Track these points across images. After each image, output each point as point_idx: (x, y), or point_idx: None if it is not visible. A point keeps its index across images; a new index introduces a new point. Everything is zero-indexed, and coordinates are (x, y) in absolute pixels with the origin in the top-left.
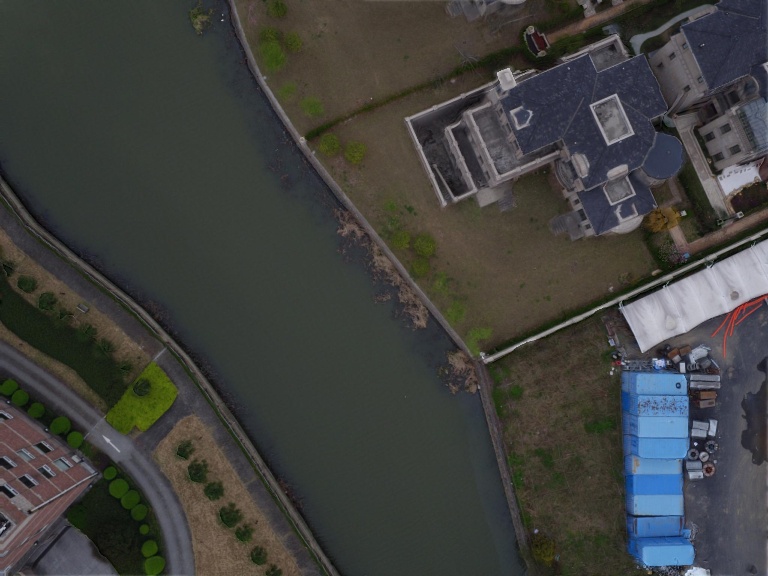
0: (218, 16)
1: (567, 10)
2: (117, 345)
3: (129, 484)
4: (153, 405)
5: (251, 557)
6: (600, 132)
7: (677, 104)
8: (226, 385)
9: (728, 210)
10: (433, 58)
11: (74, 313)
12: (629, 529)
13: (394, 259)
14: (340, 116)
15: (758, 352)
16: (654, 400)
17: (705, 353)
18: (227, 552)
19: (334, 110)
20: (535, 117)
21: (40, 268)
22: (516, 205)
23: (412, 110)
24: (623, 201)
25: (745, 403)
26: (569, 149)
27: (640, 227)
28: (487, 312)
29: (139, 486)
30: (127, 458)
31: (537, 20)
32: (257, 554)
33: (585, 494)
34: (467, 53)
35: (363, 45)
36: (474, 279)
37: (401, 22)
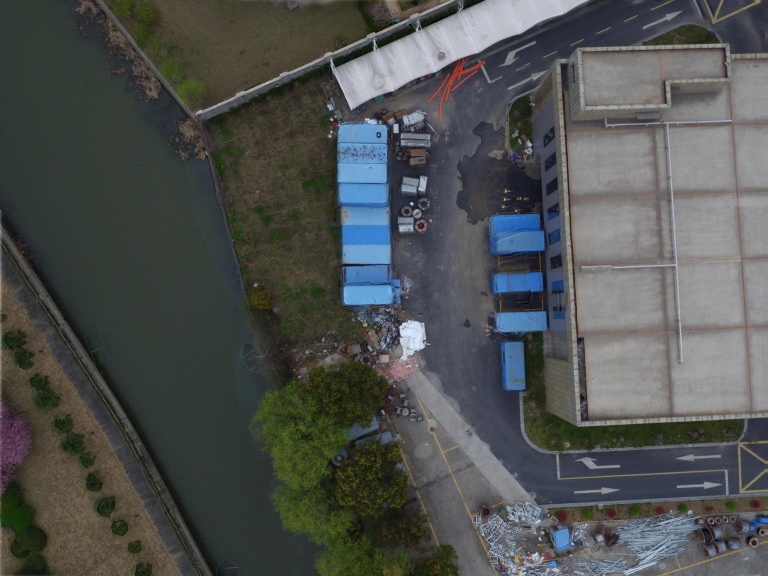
0: None
1: None
2: None
3: None
4: None
5: None
6: None
7: None
8: None
9: None
10: None
11: None
12: (339, 278)
13: (123, 30)
14: None
15: (474, 117)
16: (354, 147)
17: (422, 118)
18: None
19: None
20: None
21: None
22: None
23: None
24: None
25: (461, 165)
26: None
27: None
28: (209, 78)
29: None
30: None
31: None
32: None
33: (302, 249)
34: None
35: None
36: (197, 47)
37: None
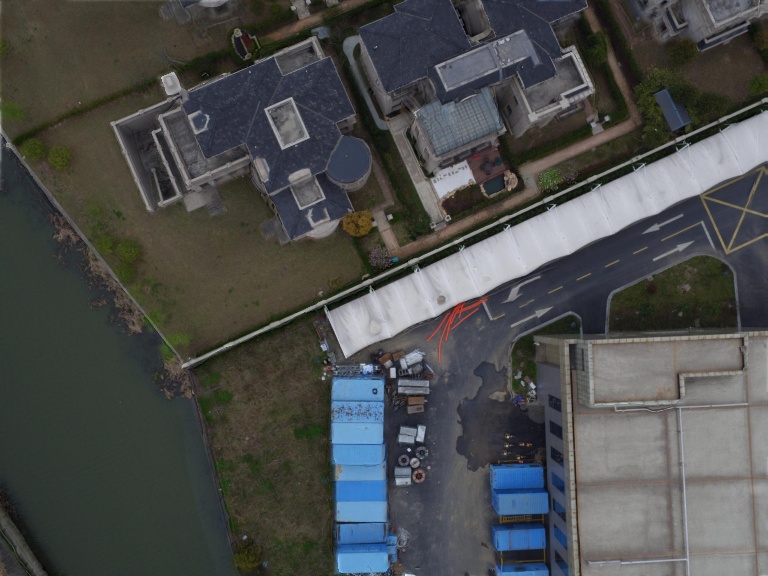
0: None
1: (277, 12)
2: None
3: None
4: None
5: None
6: (275, 136)
7: (375, 106)
8: None
9: (442, 213)
10: (143, 62)
11: None
12: (333, 536)
13: (104, 264)
14: (48, 121)
15: (475, 357)
16: (348, 406)
17: (420, 358)
18: None
19: (44, 115)
20: (211, 121)
21: None
22: (226, 209)
23: (121, 114)
24: (313, 205)
25: (461, 408)
26: (251, 153)
27: (336, 231)
28: (195, 317)
29: None
30: None
31: (245, 22)
32: None
33: (294, 500)
34: (175, 56)
35: (73, 49)
36: (182, 284)
37: (113, 26)
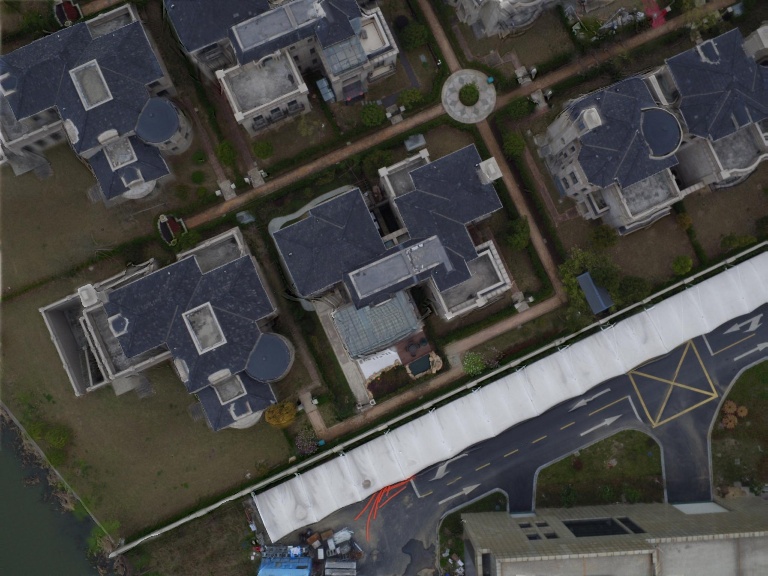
0: None
1: (203, 196)
2: None
3: None
4: None
5: None
6: (192, 341)
7: None
8: None
9: (368, 394)
10: (71, 246)
11: None
12: None
13: (35, 446)
14: None
15: (403, 534)
16: None
17: (348, 536)
18: None
19: None
20: (131, 325)
21: None
22: (155, 391)
23: (50, 299)
24: (235, 400)
25: None
26: (172, 353)
27: (259, 422)
28: (125, 499)
29: None
30: None
31: (171, 207)
32: None
33: None
34: (103, 241)
35: (2, 234)
36: (112, 467)
37: (42, 209)
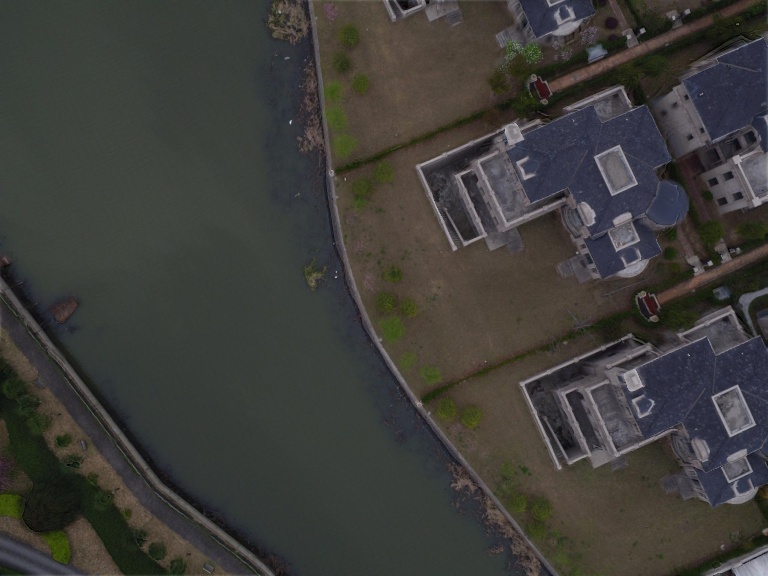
0: (332, 273)
1: (678, 272)
2: None
3: None
4: None
5: None
6: (722, 423)
7: None
8: None
9: None
10: (545, 320)
11: (201, 575)
12: None
13: (509, 517)
14: (455, 380)
15: None
16: None
17: None
18: None
19: (449, 372)
20: (657, 407)
21: (166, 529)
22: (628, 464)
23: (525, 372)
24: (740, 478)
25: None
26: (689, 433)
27: (755, 498)
28: (600, 570)
29: None
30: None
31: (648, 284)
32: None
33: None
34: (579, 316)
35: (477, 308)
36: (588, 538)
37: (513, 283)
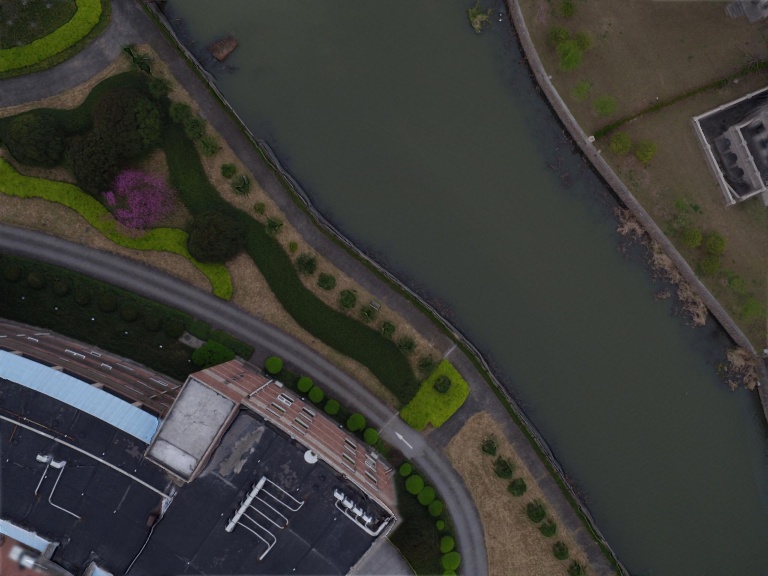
0: (496, 16)
1: None
2: (411, 342)
3: (424, 480)
4: (447, 402)
5: (553, 552)
6: None
7: None
8: (510, 382)
9: None
10: (716, 59)
11: None
12: None
13: (679, 257)
14: (627, 116)
15: None
16: None
17: None
18: (520, 547)
19: (620, 110)
20: None
21: (331, 266)
22: None
23: (697, 110)
24: None
25: None
26: None
27: None
28: None
29: (432, 482)
30: (420, 454)
31: None
32: (561, 549)
33: None
34: (751, 54)
35: (647, 45)
36: (759, 277)
37: (682, 23)
